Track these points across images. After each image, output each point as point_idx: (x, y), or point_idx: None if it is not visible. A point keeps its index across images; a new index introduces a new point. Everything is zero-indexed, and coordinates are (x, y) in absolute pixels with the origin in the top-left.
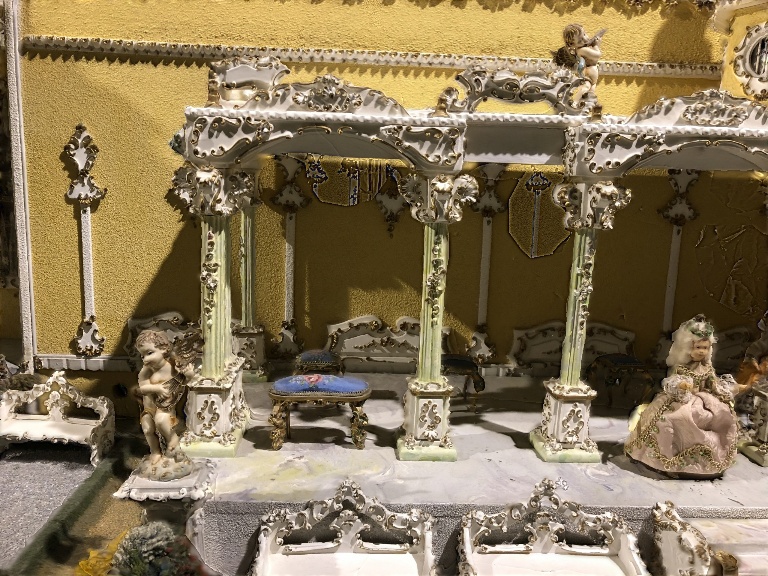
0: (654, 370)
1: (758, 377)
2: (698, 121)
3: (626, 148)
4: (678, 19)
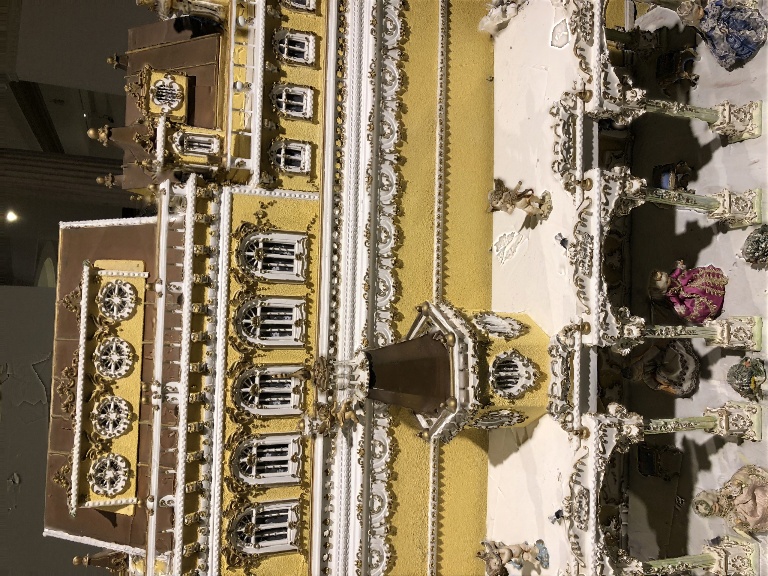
0: (622, 398)
1: (671, 387)
2: (584, 518)
3: (604, 568)
4: (400, 412)
